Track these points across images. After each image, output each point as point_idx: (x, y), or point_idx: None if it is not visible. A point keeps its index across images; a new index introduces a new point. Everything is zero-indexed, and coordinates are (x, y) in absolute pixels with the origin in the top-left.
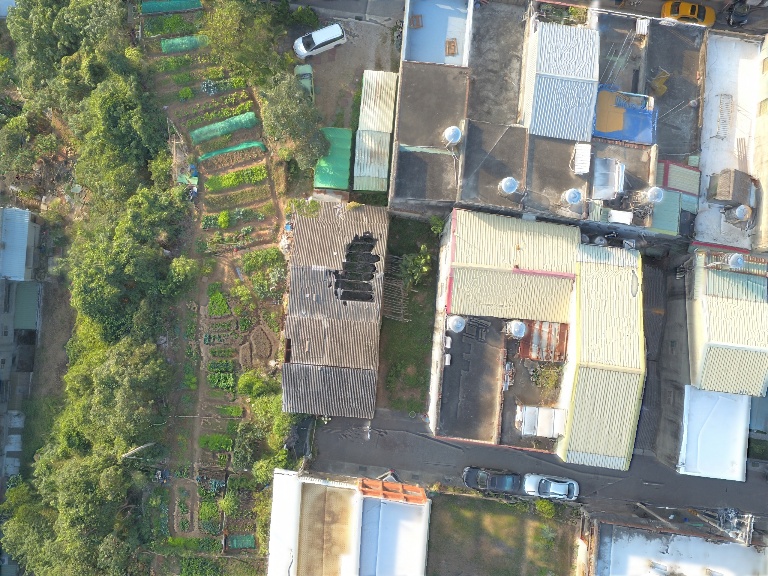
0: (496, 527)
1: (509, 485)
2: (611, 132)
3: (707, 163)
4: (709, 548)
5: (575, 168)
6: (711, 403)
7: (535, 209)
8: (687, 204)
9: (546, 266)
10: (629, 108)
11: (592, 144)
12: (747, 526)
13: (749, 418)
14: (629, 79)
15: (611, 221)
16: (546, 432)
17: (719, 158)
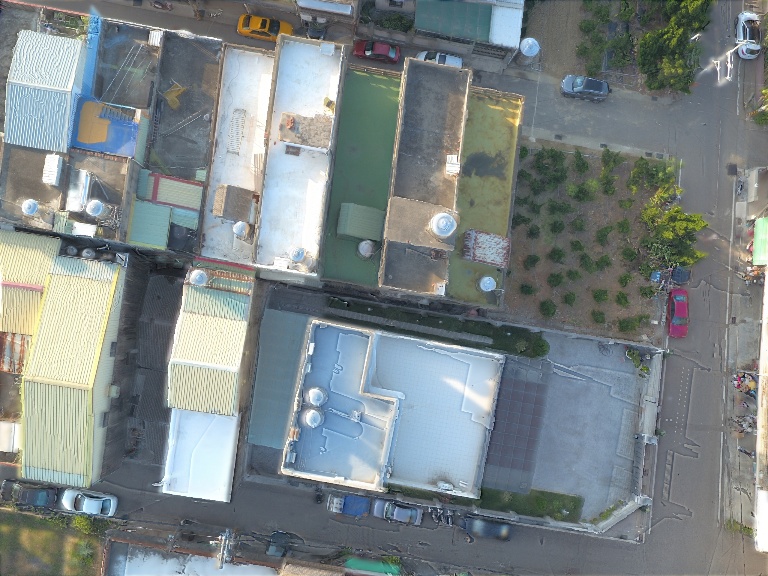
0: (32, 542)
1: (42, 499)
2: (94, 143)
3: (222, 178)
4: (227, 569)
5: (43, 179)
6: (207, 421)
7: (7, 219)
8: (182, 219)
9: (8, 277)
10: (113, 120)
11: (70, 155)
12: (221, 548)
13: (238, 438)
14: (146, 91)
15: (75, 233)
16: (5, 447)
17: (235, 173)
